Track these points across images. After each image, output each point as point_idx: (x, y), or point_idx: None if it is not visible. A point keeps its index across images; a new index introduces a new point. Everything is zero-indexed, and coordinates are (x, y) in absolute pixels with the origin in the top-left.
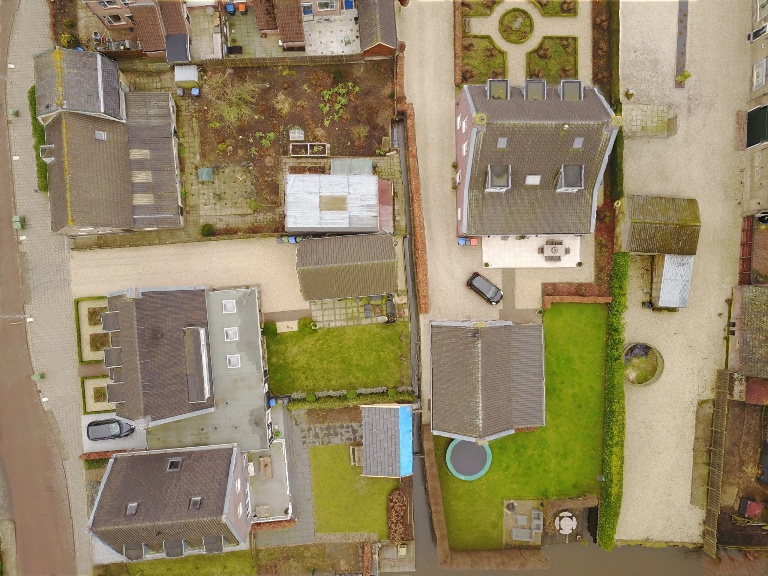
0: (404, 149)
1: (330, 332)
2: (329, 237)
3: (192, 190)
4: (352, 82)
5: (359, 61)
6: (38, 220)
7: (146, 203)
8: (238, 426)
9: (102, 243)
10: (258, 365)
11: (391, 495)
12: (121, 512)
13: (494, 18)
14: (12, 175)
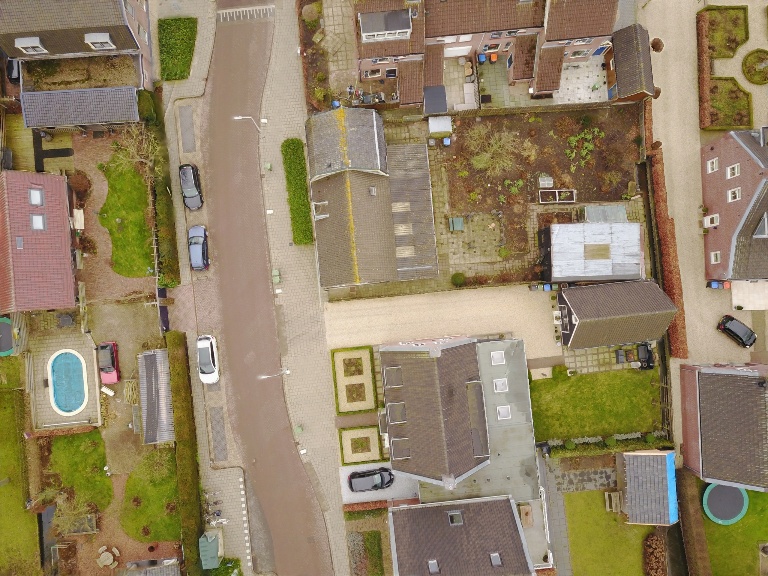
0: (646, 192)
1: (583, 378)
2: (591, 285)
3: (441, 239)
4: (598, 127)
5: (605, 106)
6: (293, 273)
7: (408, 255)
8: (510, 477)
9: (355, 294)
10: (527, 416)
11: (648, 540)
12: (425, 570)
13: (737, 59)
14: (266, 229)
